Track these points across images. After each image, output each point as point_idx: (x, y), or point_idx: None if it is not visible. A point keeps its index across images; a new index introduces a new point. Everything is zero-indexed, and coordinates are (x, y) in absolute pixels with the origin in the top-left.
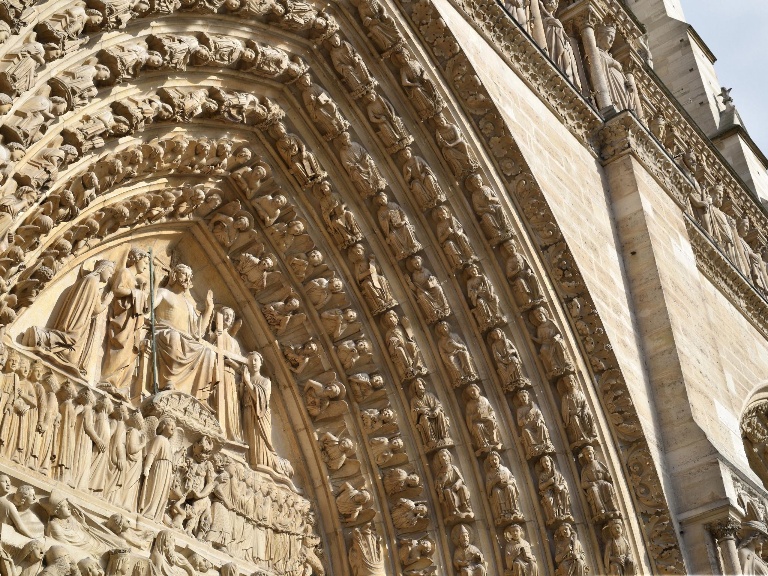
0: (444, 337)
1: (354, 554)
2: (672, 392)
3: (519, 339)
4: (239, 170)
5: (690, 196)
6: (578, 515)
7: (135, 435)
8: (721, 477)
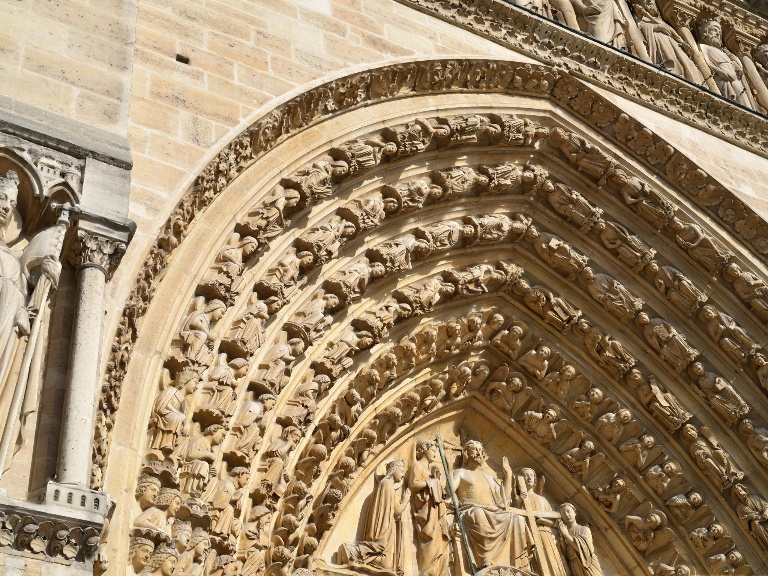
0: (751, 435)
1: None
2: None
3: None
4: (497, 336)
5: None
6: None
7: None
8: None
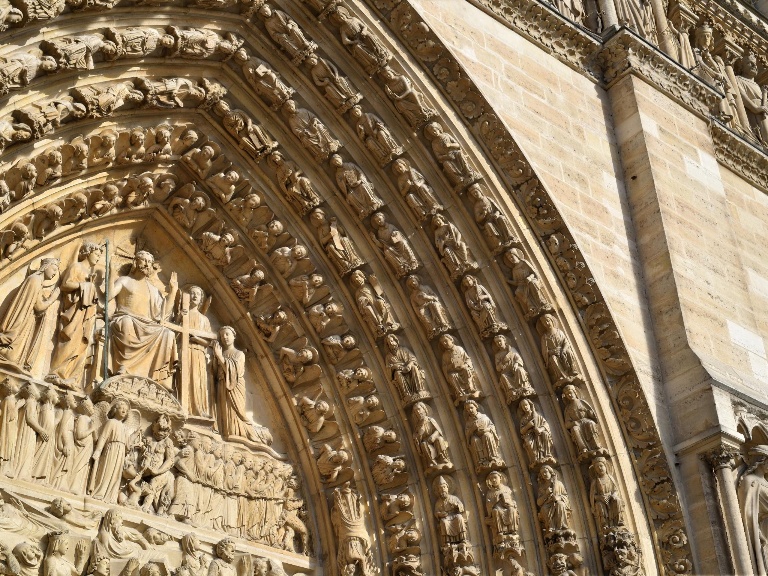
0: (415, 290)
1: (334, 513)
2: (669, 319)
3: (494, 284)
4: (188, 153)
5: (747, 103)
6: (563, 456)
7: (83, 421)
8: (714, 404)
